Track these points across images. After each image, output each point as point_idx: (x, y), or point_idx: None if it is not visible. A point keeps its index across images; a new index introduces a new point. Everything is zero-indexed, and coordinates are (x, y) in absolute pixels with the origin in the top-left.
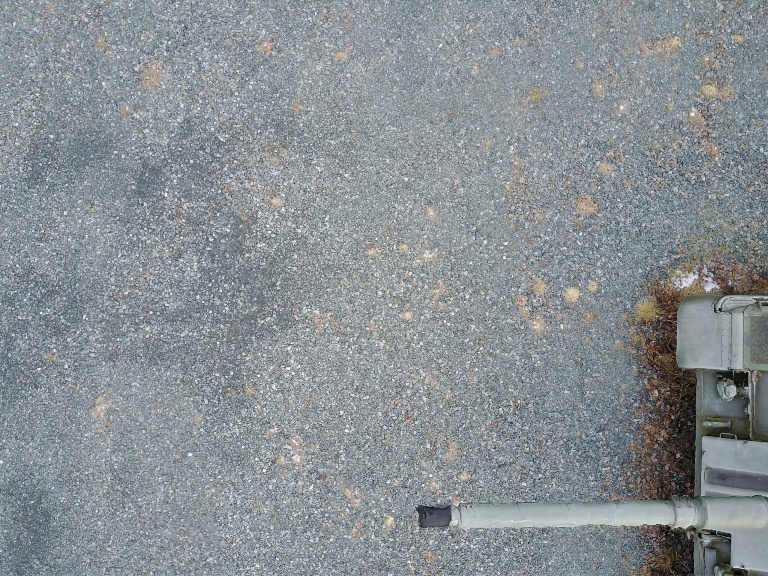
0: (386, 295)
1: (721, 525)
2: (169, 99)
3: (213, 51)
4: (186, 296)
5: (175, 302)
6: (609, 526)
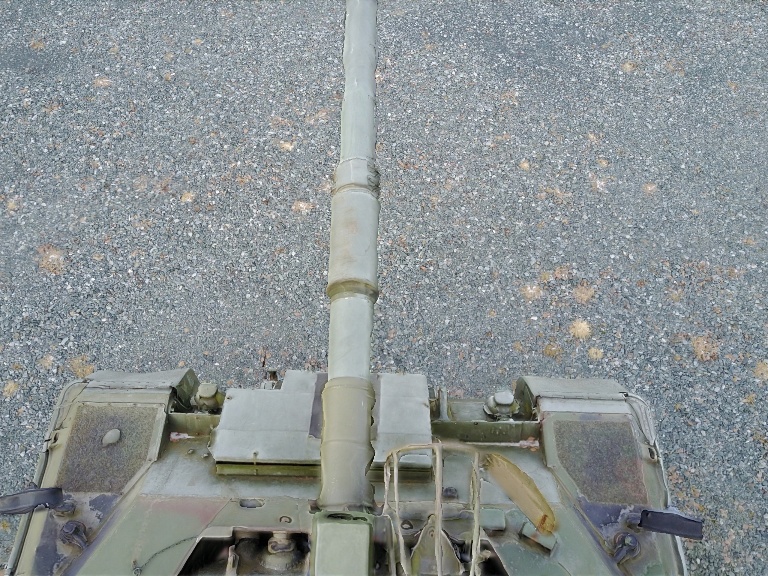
0: (545, 148)
1: (341, 217)
2: (706, 1)
3: (765, 28)
4: (518, 8)
5: (511, 1)
6: (263, 372)
